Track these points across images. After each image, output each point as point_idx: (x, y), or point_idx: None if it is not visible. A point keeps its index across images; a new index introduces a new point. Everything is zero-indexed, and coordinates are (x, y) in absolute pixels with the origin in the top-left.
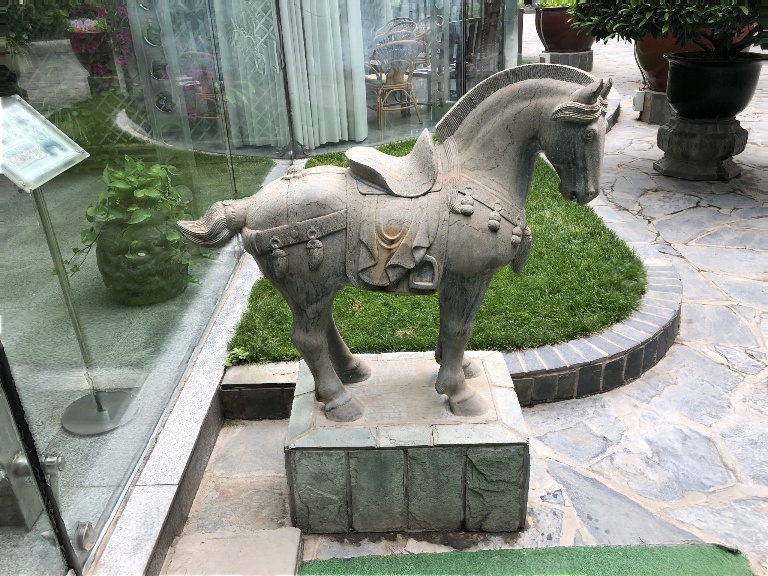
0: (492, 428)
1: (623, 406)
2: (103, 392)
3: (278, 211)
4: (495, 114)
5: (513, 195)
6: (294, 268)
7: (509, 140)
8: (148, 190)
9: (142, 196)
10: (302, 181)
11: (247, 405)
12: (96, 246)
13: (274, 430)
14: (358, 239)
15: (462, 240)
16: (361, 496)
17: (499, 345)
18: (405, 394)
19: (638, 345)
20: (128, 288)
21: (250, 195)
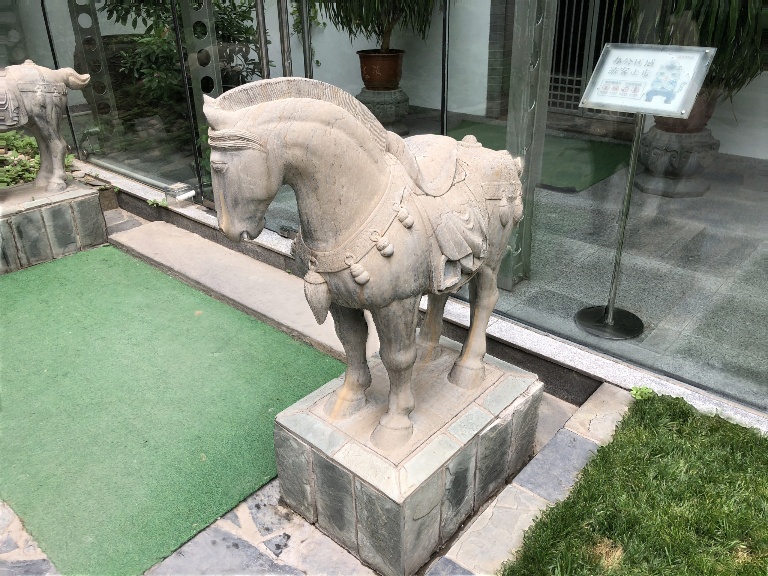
0: (307, 404)
1: None
2: (641, 327)
3: None
4: None
5: None
6: None
7: None
8: None
9: None
10: None
11: None
12: None
13: None
14: None
15: None
16: None
17: None
18: None
19: None
20: None
21: None
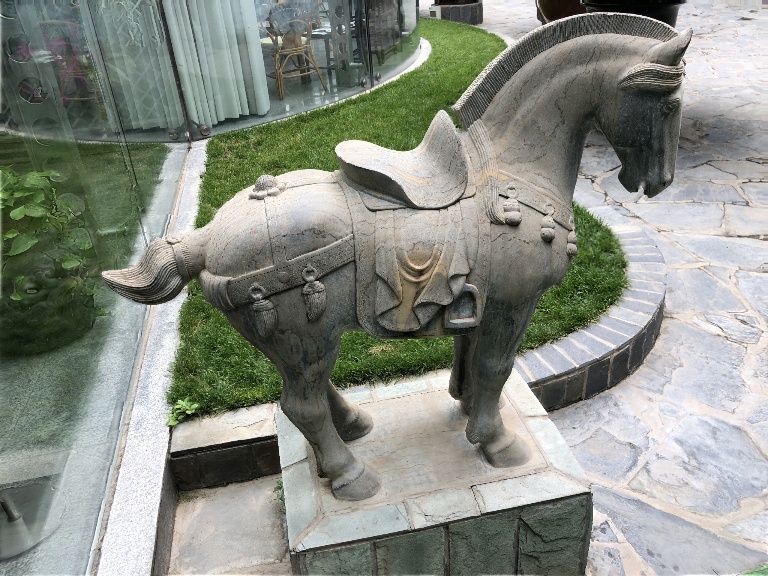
0: (545, 479)
1: (637, 401)
2: (11, 489)
3: (257, 248)
4: (538, 86)
5: (563, 191)
6: (286, 322)
7: (558, 120)
8: (29, 209)
9: (22, 217)
10: (283, 200)
11: (206, 471)
12: None
13: (246, 497)
14: (373, 273)
15: (510, 259)
16: None
17: None
18: (424, 446)
19: (641, 330)
20: (19, 335)
21: (148, 192)
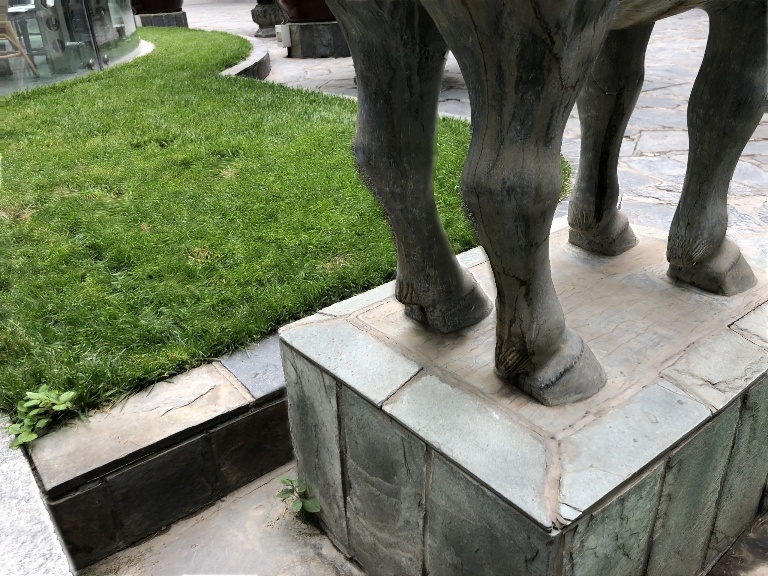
0: None
1: None
2: None
3: None
4: None
5: None
6: None
7: None
8: None
9: None
10: None
11: (126, 511)
12: None
13: (219, 535)
14: None
15: None
16: (661, 553)
17: None
18: (600, 300)
19: None
20: None
21: None
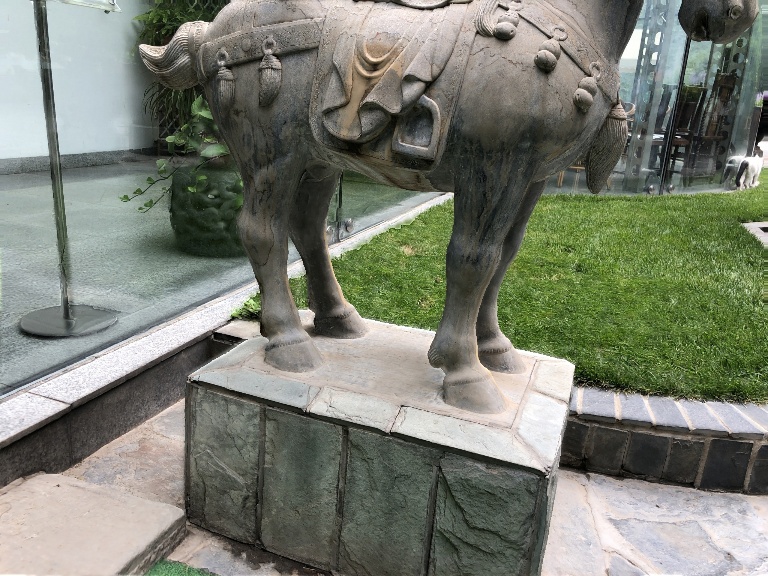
0: (494, 434)
1: None
2: (89, 307)
3: (234, 11)
4: None
5: (594, 27)
6: (241, 101)
7: None
8: None
9: None
10: None
11: None
12: (172, 180)
13: None
14: (331, 63)
15: (486, 78)
16: (276, 489)
17: (590, 377)
18: (392, 364)
19: None
20: (192, 233)
21: (384, 207)
